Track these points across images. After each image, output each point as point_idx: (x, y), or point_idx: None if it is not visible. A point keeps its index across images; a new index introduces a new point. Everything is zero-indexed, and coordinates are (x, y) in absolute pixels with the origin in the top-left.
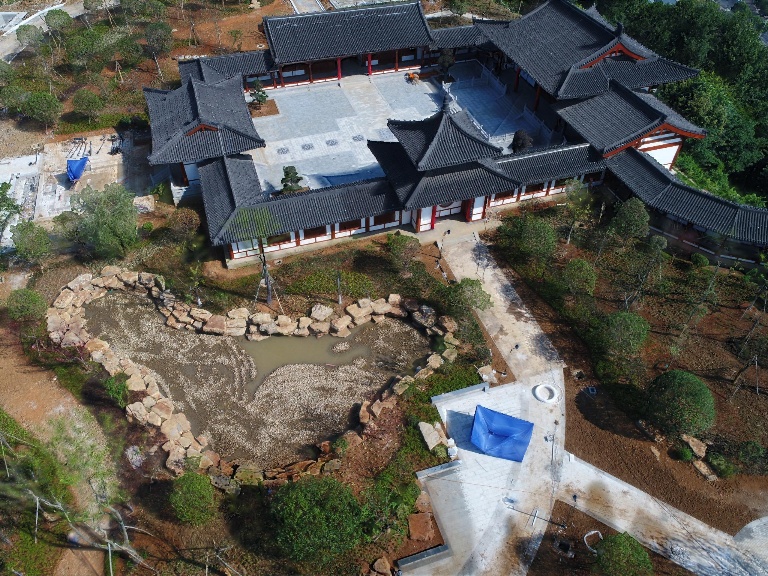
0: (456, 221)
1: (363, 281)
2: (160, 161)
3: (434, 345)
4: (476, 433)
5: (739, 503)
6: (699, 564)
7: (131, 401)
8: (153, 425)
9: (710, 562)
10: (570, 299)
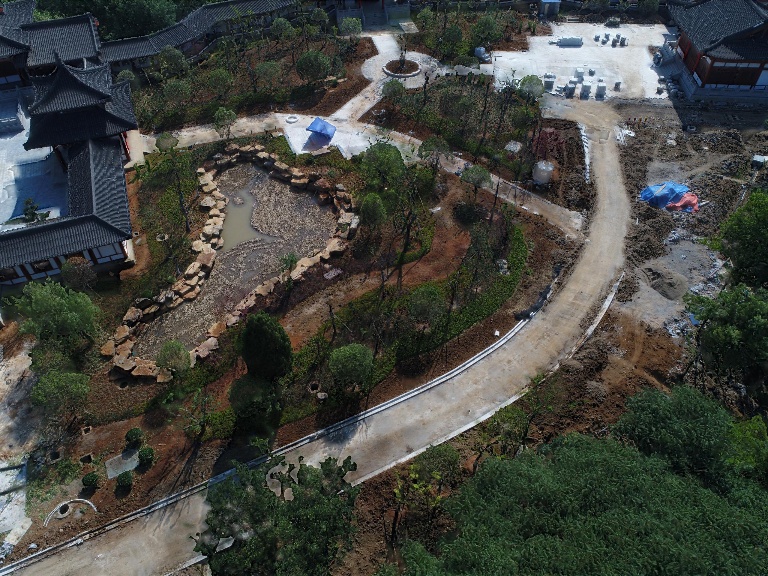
0: None
1: None
2: None
3: (244, 162)
4: None
5: (357, 77)
6: None
7: None
8: (308, 269)
9: None
10: (223, 103)
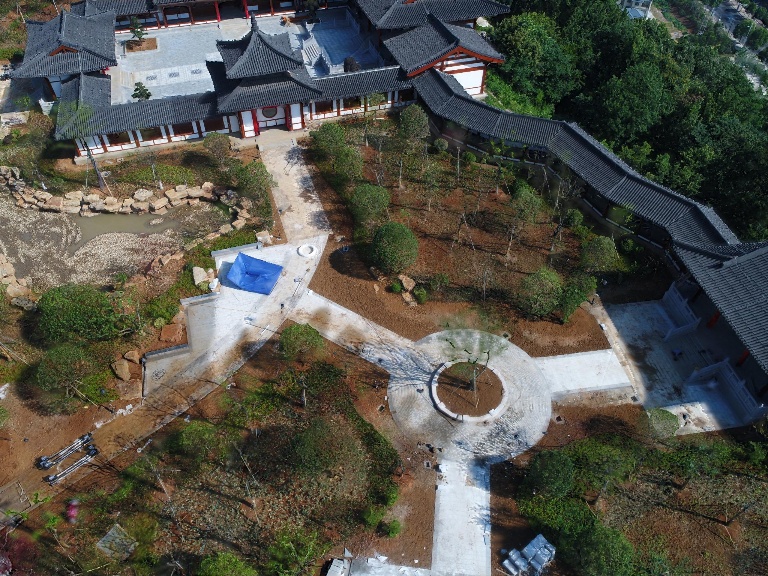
0: (280, 130)
1: (186, 173)
2: (23, 75)
3: None
4: (233, 272)
5: (428, 321)
6: (380, 358)
7: None
8: None
9: (389, 357)
10: (352, 186)
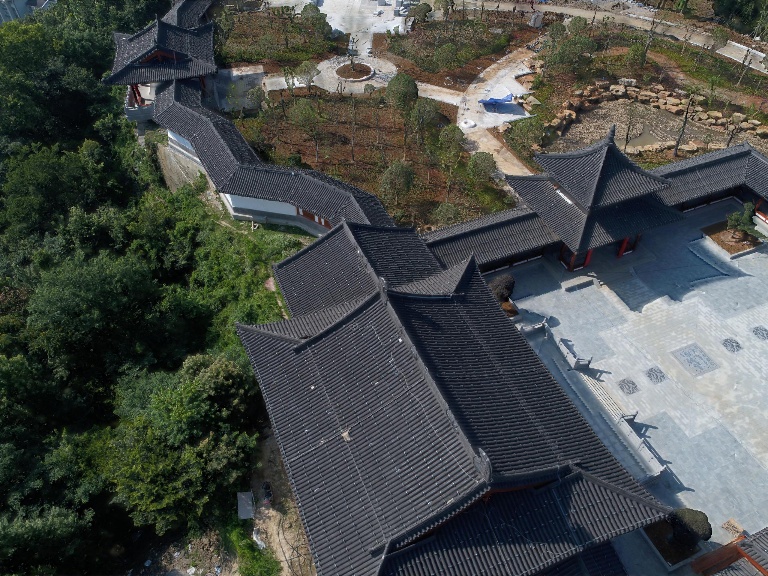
0: None
1: None
2: None
3: None
4: None
5: (376, 93)
6: None
7: (709, 108)
8: None
9: None
10: None
